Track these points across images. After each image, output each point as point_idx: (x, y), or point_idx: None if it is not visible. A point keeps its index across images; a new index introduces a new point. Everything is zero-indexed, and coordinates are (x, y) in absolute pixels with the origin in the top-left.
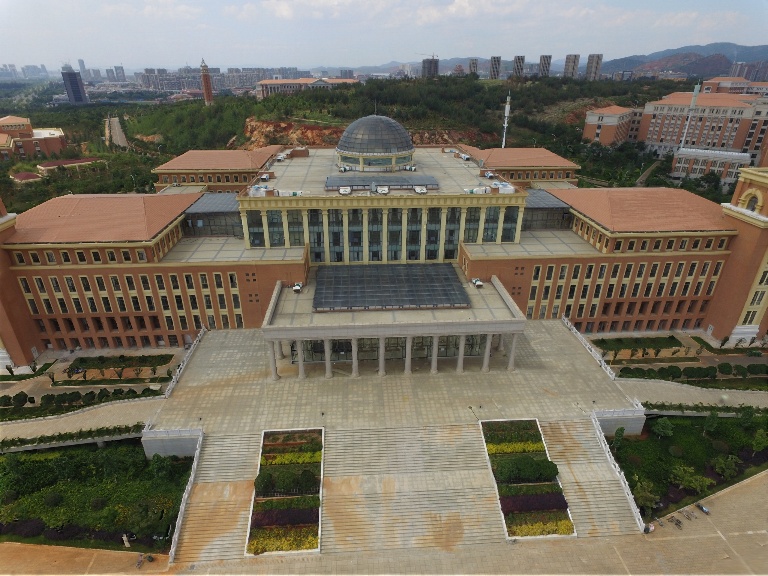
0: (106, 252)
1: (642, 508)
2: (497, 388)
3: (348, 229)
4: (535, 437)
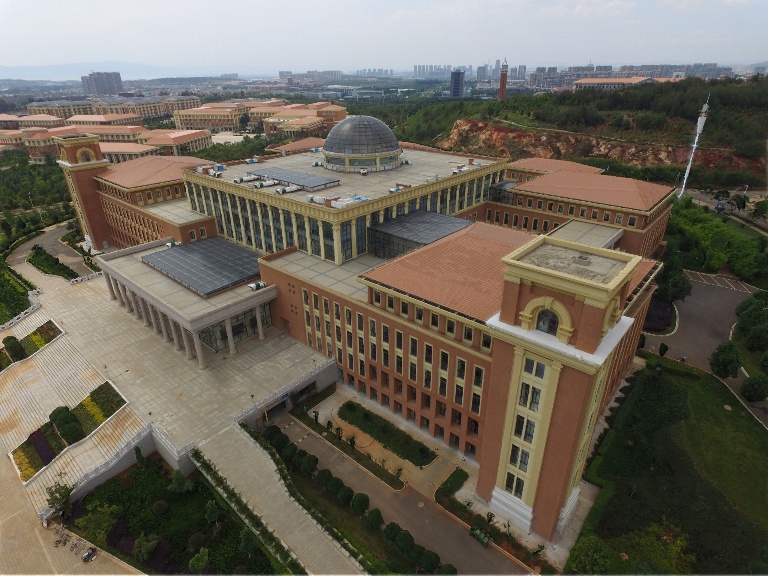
0: (121, 191)
1: None
2: (165, 372)
3: (232, 211)
4: (107, 412)
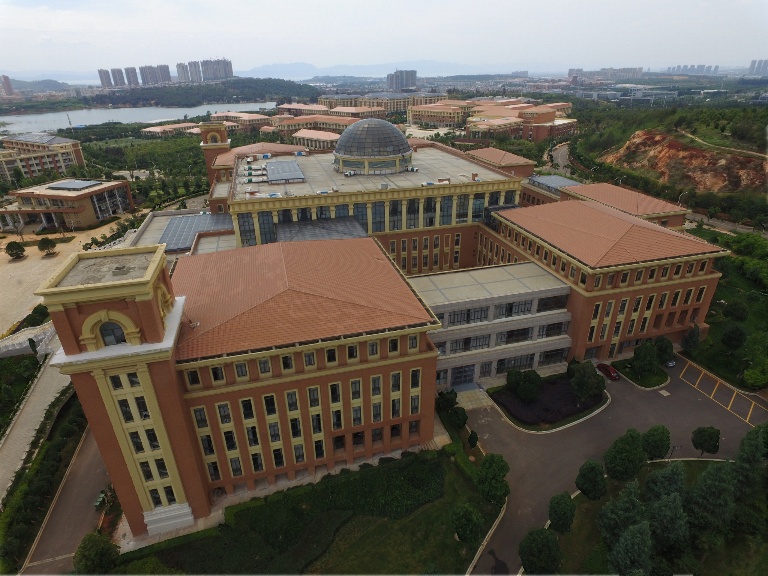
0: None
1: None
2: None
3: None
4: None
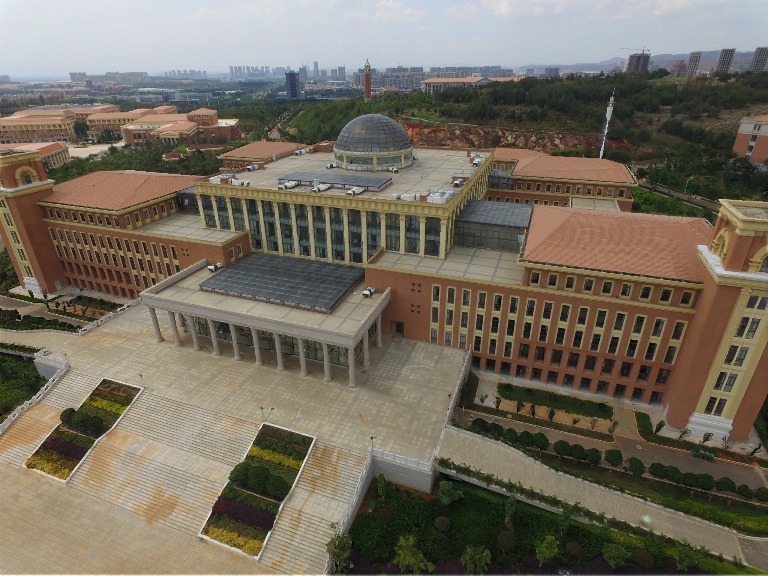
0: (96, 216)
1: None
2: (317, 399)
3: (280, 221)
4: (298, 454)
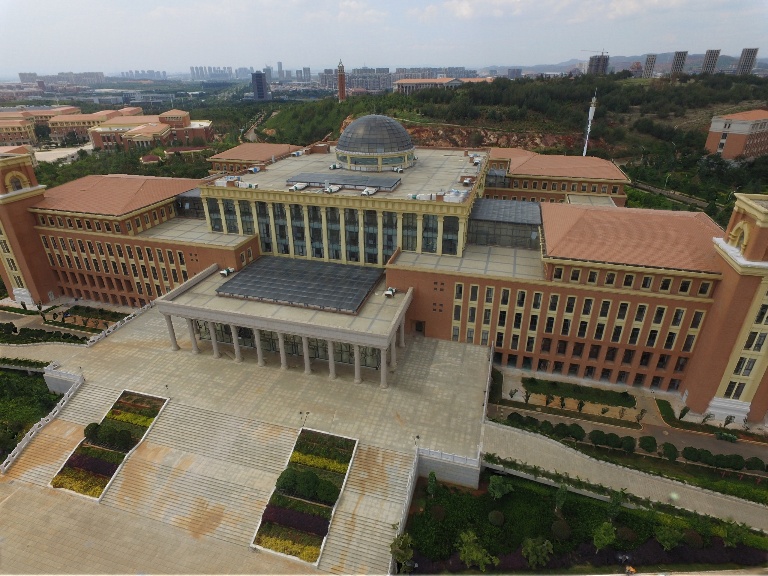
0: (94, 222)
1: (401, 563)
2: (351, 401)
3: (292, 223)
4: (343, 457)
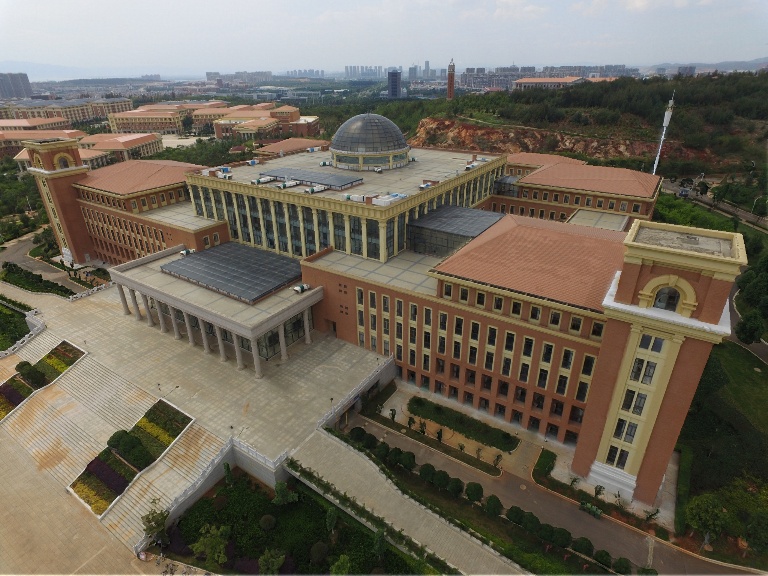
0: (111, 199)
1: None
2: (220, 384)
3: (251, 214)
4: (173, 431)
